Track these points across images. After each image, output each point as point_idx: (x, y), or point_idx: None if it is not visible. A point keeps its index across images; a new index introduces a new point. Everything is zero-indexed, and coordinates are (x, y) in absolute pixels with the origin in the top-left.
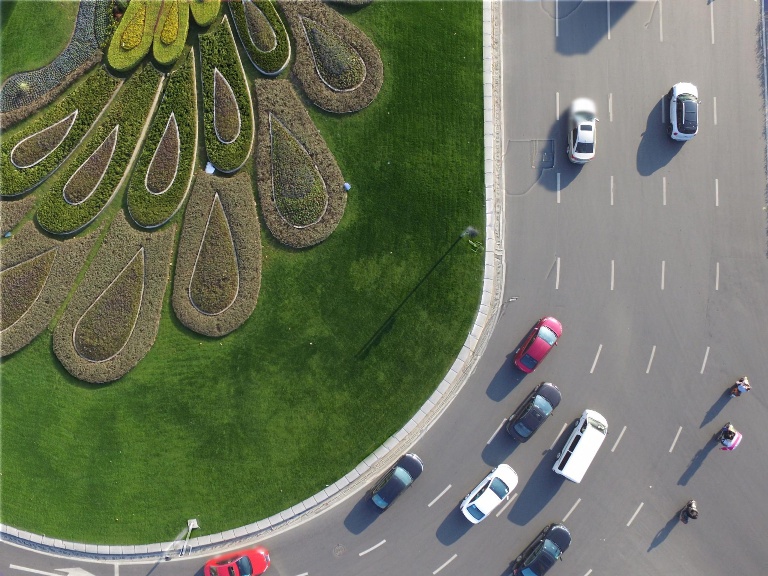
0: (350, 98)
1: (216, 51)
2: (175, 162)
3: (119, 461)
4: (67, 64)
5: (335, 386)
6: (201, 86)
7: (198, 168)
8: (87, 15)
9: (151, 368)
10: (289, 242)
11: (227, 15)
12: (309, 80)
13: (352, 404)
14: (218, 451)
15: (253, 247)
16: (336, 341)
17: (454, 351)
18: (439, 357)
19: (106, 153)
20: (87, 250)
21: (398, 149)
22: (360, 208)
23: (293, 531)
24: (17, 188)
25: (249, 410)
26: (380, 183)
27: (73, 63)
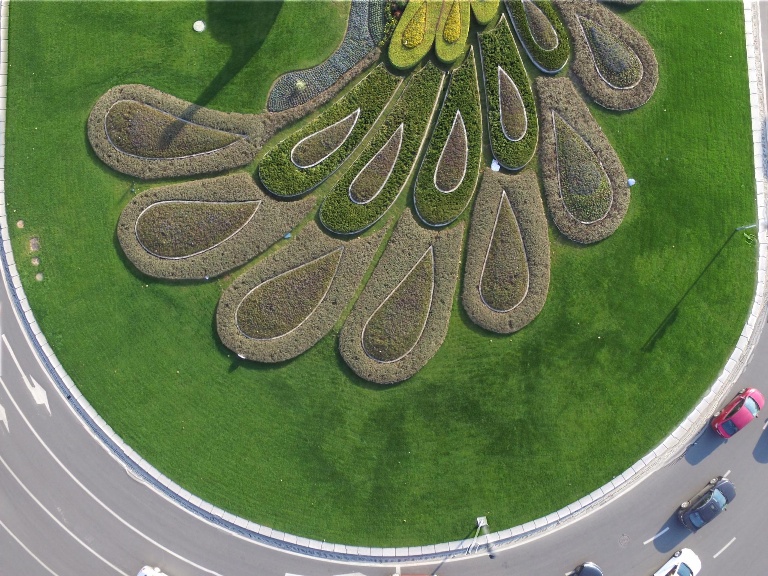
0: (630, 96)
1: (498, 49)
2: (464, 160)
3: (408, 462)
4: (343, 62)
5: (626, 379)
6: (483, 84)
7: (483, 166)
8: (360, 13)
9: (441, 367)
10: (577, 238)
11: (504, 14)
12: (590, 78)
13: (641, 396)
14: (509, 447)
15: (543, 243)
16: (623, 334)
17: (733, 341)
18: (719, 347)
19: (393, 152)
20: (374, 250)
21: (675, 145)
22: (642, 203)
23: (578, 524)
24: (299, 188)
25: (540, 405)
26: (660, 179)
27: (349, 61)
